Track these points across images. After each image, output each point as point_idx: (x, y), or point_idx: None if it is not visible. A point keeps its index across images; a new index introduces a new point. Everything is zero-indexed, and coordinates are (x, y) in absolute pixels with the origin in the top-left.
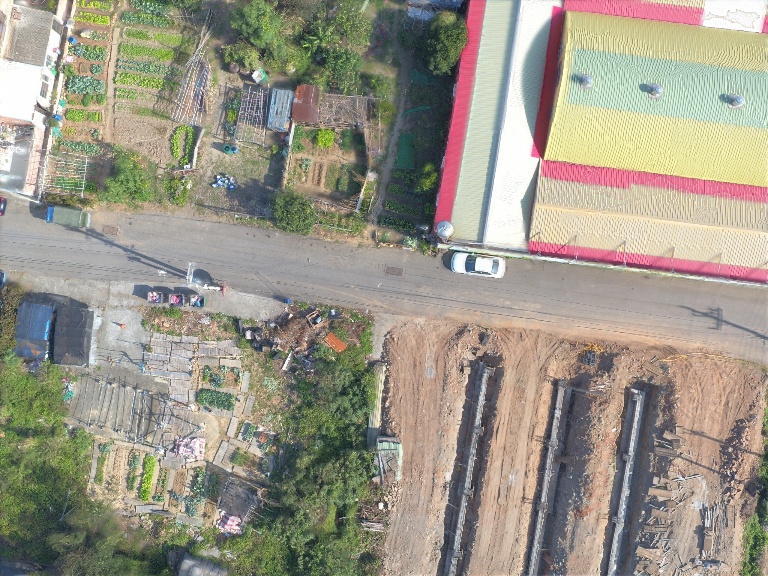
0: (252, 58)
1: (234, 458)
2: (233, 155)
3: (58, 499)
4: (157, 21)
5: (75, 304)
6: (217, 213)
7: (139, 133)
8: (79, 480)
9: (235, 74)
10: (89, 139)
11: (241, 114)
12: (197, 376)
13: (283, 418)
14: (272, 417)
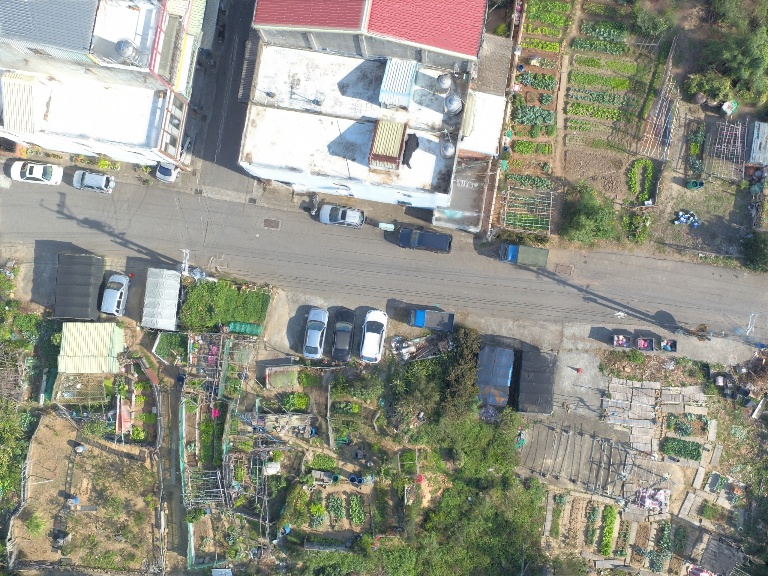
0: (728, 89)
1: (704, 511)
2: (695, 190)
3: (514, 553)
4: (611, 48)
5: (526, 347)
6: (680, 252)
7: (592, 166)
8: (533, 533)
9: (696, 105)
10: (538, 172)
11: (717, 148)
12: (660, 424)
13: (754, 469)
14: (741, 467)
